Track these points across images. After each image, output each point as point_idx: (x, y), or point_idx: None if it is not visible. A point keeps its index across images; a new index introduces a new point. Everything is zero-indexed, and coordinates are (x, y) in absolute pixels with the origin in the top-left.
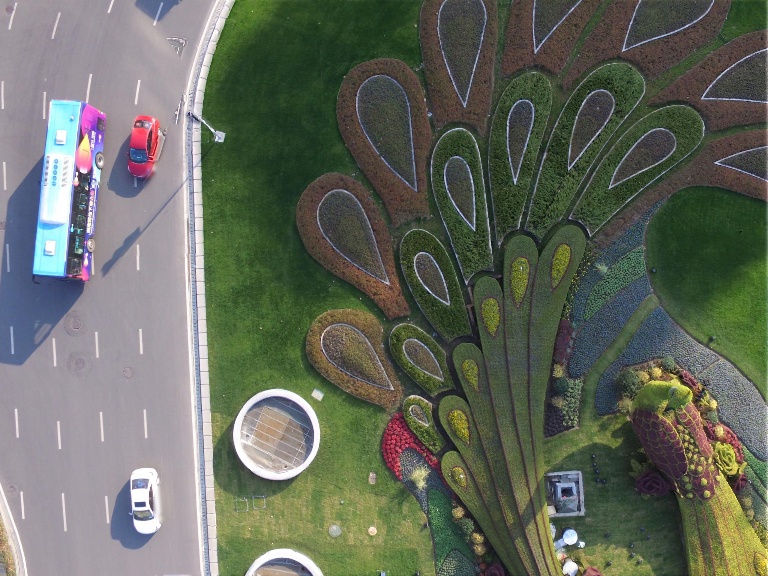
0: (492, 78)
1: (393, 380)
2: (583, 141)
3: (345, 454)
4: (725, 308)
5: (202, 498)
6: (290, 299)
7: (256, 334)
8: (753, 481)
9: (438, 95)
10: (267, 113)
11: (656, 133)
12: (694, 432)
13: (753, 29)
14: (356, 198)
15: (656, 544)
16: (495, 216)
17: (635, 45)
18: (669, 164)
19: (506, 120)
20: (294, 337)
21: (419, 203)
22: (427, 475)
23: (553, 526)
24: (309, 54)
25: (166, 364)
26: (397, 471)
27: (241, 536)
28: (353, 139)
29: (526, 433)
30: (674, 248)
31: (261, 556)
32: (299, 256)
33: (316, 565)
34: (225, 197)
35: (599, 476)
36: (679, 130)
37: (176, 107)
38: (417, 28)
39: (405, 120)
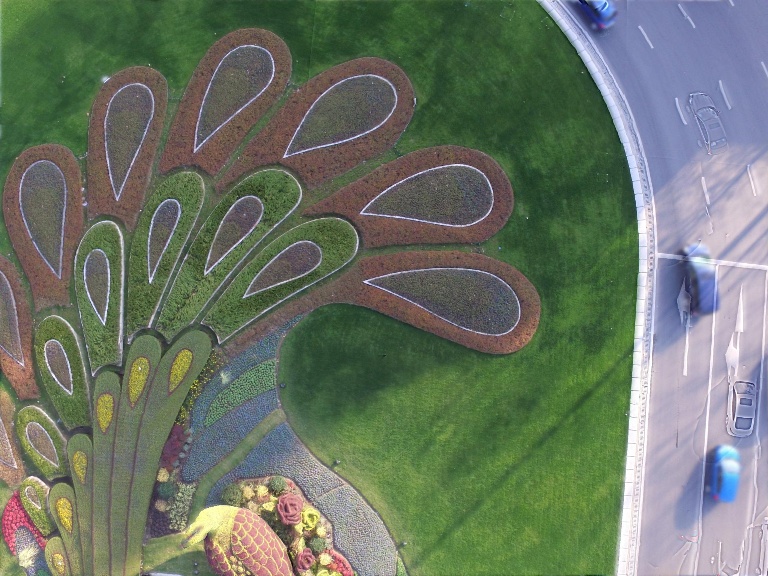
0: (149, 174)
1: (16, 459)
2: (223, 247)
3: None
4: (356, 433)
5: None
6: None
7: None
8: None
9: (93, 186)
10: None
11: (301, 246)
12: (250, 565)
13: (433, 144)
14: (6, 278)
15: None
16: (127, 312)
17: (298, 152)
18: (312, 279)
19: (150, 218)
20: None
21: (58, 291)
22: (33, 556)
23: None
24: None
25: None
26: (11, 547)
27: None
28: (11, 221)
29: (120, 533)
30: (309, 365)
31: None
32: None
33: None
34: None
35: None
36: (326, 245)
37: None
38: (89, 117)
39: (59, 207)
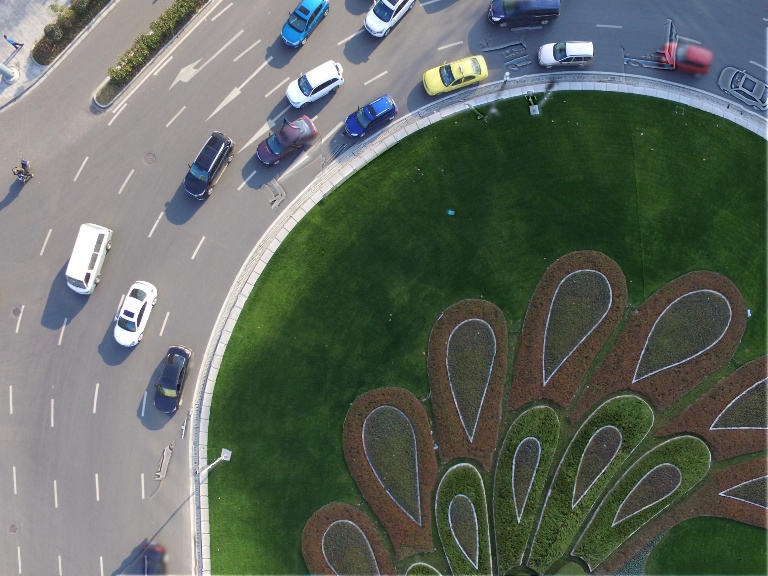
0: (500, 411)
1: None
2: (588, 480)
3: None
4: None
5: None
6: None
7: None
8: None
9: (445, 430)
10: (273, 436)
11: (662, 469)
12: None
13: (767, 351)
14: (361, 529)
15: None
16: (498, 553)
17: (646, 376)
18: (673, 499)
19: (512, 459)
20: None
21: (423, 539)
22: None
23: None
24: (316, 378)
25: None
26: None
27: None
28: (359, 472)
29: None
30: None
31: None
32: None
33: None
34: (231, 516)
35: None
36: (685, 466)
37: (182, 422)
38: (425, 356)
39: (411, 455)
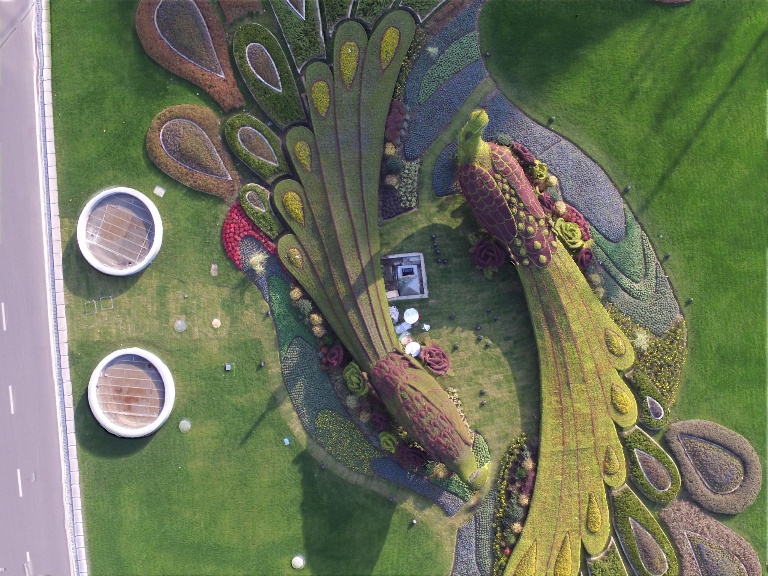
0: None
1: (230, 170)
2: None
3: (187, 248)
4: (564, 90)
5: (53, 304)
6: (131, 100)
7: (100, 137)
8: (604, 262)
9: None
10: None
11: None
12: (514, 182)
13: None
14: None
15: (504, 326)
16: (325, 6)
17: None
18: None
19: None
20: (135, 136)
21: None
22: (265, 259)
23: (396, 309)
24: None
25: (17, 174)
26: (237, 260)
27: (91, 339)
28: None
29: (358, 208)
30: (508, 33)
31: (108, 355)
32: (139, 59)
33: (163, 362)
34: (71, 11)
35: (441, 257)
36: None
37: None
38: None
39: None
